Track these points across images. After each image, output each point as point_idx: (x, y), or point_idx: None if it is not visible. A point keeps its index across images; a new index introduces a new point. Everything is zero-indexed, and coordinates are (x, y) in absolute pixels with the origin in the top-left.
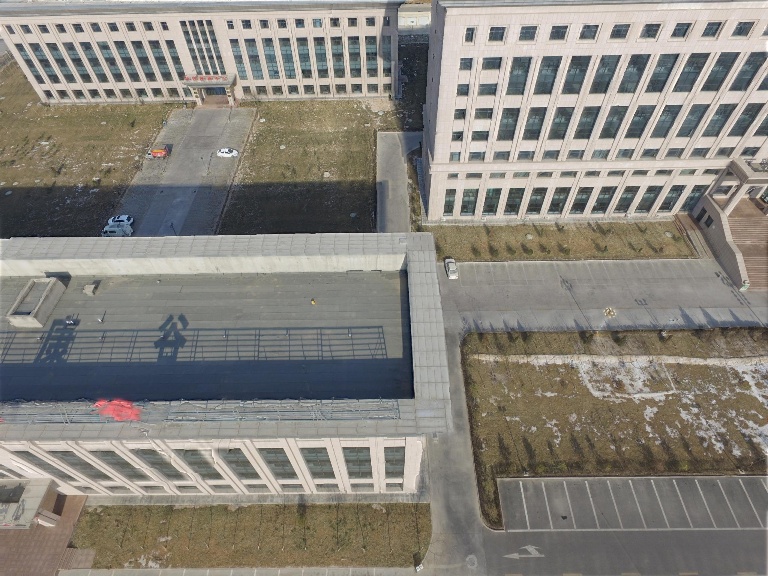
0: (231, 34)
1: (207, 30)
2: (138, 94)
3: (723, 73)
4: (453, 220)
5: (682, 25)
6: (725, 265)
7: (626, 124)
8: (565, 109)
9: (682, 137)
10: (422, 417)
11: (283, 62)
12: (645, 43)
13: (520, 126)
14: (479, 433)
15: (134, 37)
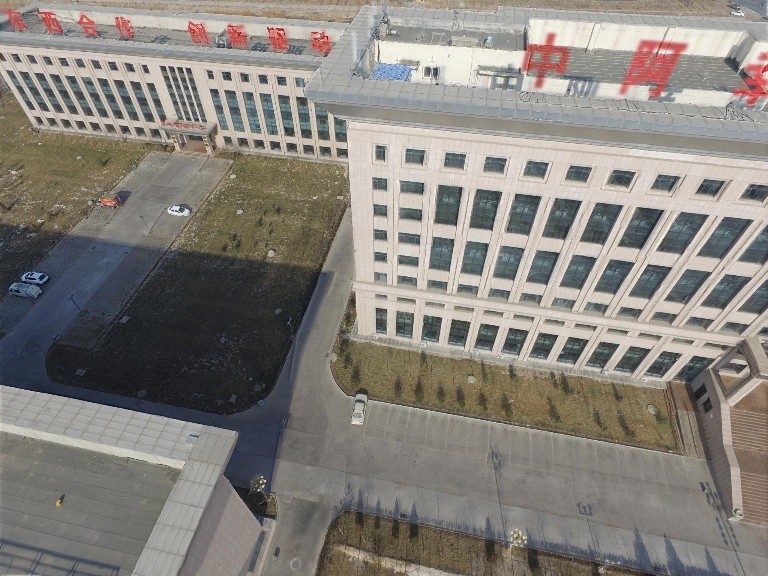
0: (211, 84)
1: (187, 77)
2: (122, 130)
3: (729, 240)
4: (387, 339)
5: (667, 177)
6: (717, 474)
7: (595, 277)
8: (513, 249)
9: (673, 302)
10: None
11: (265, 117)
12: (614, 192)
13: (457, 258)
14: None
15: (116, 76)
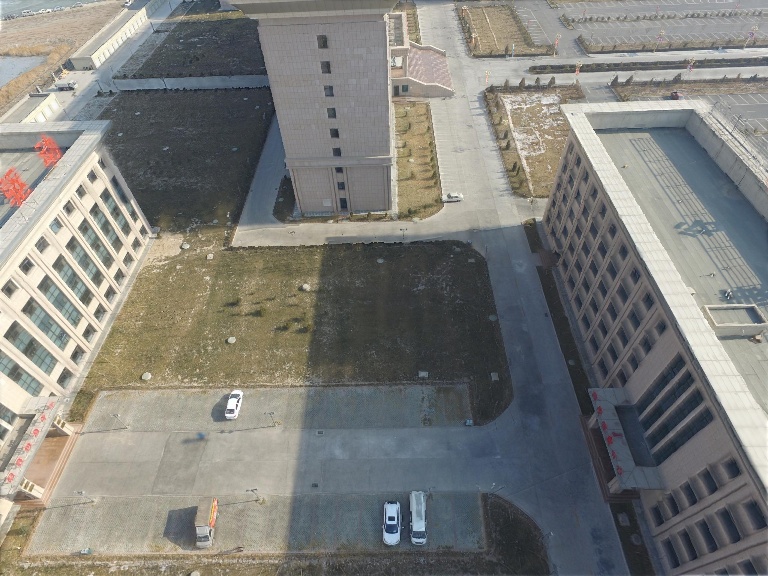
0: None
1: None
2: None
3: None
4: (392, 196)
5: None
6: (436, 95)
7: None
8: None
9: None
10: (702, 107)
11: (59, 314)
12: None
13: None
14: None
15: None
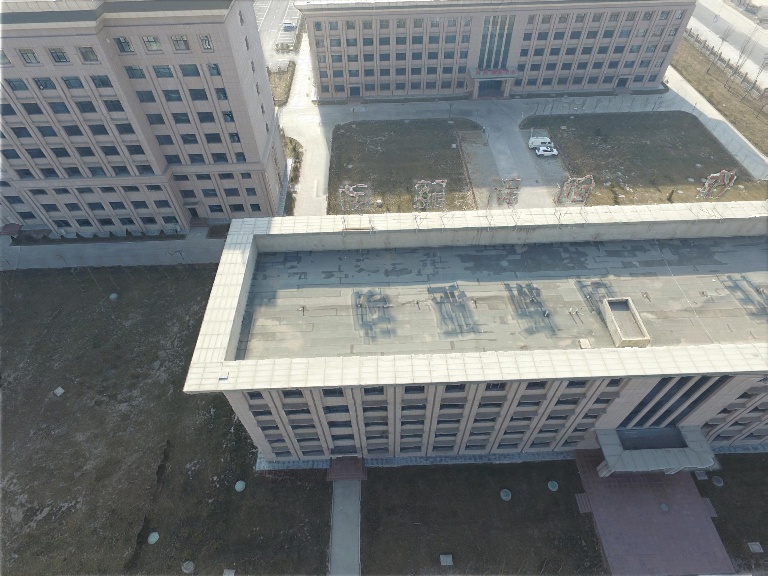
0: None
1: None
2: None
3: None
4: None
5: None
6: None
7: None
8: None
9: None
10: None
11: None
12: None
13: None
14: (289, 80)
15: None
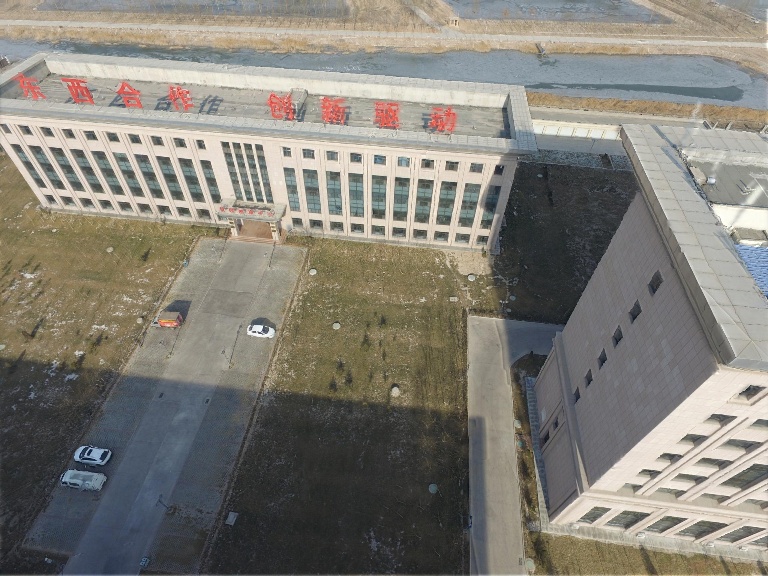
0: (286, 162)
1: (256, 155)
2: (160, 210)
3: None
4: (590, 529)
5: None
6: None
7: None
8: None
9: None
10: None
11: (350, 198)
12: None
13: None
14: None
15: (161, 152)
